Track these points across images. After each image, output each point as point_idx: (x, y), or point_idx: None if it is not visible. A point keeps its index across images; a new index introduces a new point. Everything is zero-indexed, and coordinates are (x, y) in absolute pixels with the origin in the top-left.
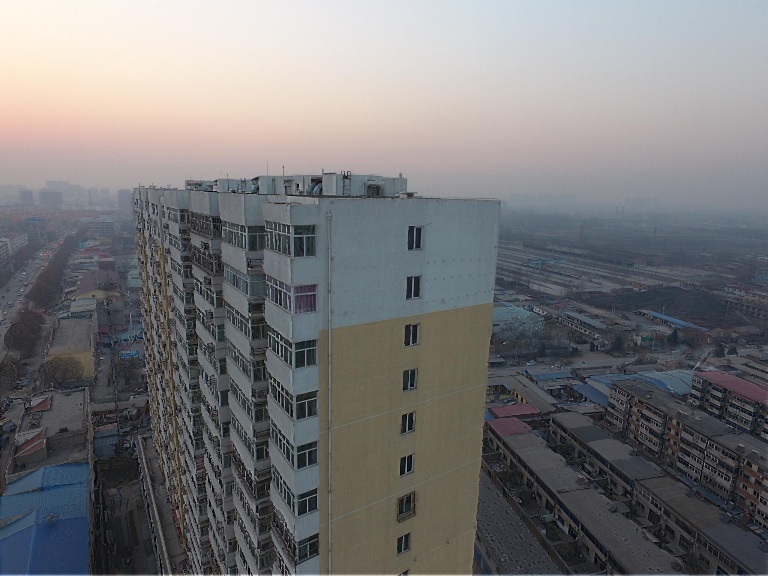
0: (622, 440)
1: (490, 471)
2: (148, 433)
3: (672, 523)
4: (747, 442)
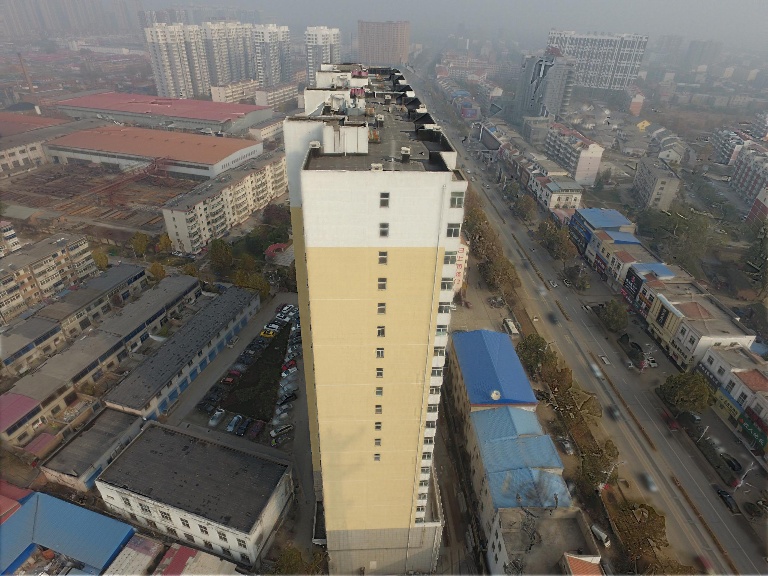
0: None
1: (97, 402)
2: None
3: None
4: None
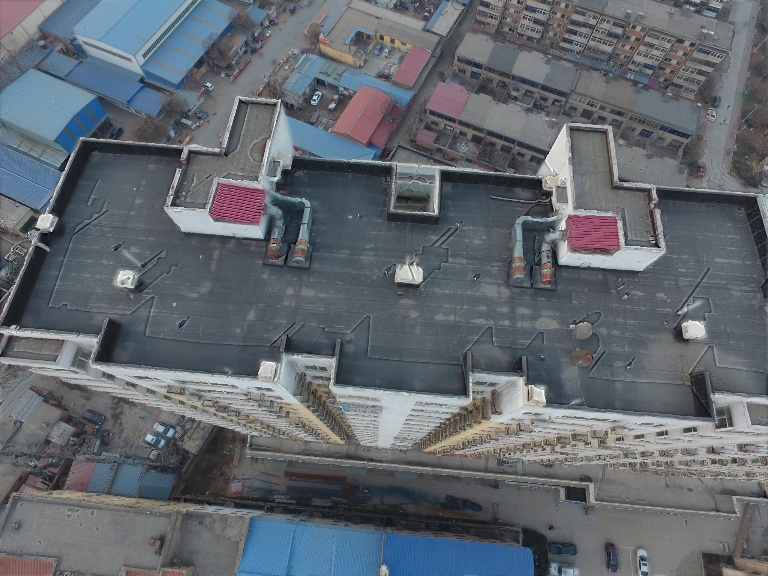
0: (502, 39)
1: (471, 159)
2: (126, 420)
3: (606, 114)
4: (623, 1)
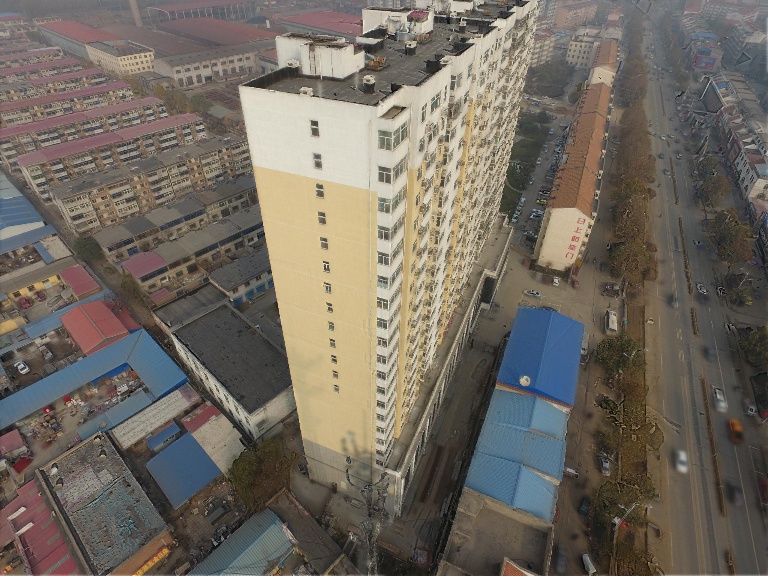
0: None
1: None
2: None
3: None
4: (167, 156)
